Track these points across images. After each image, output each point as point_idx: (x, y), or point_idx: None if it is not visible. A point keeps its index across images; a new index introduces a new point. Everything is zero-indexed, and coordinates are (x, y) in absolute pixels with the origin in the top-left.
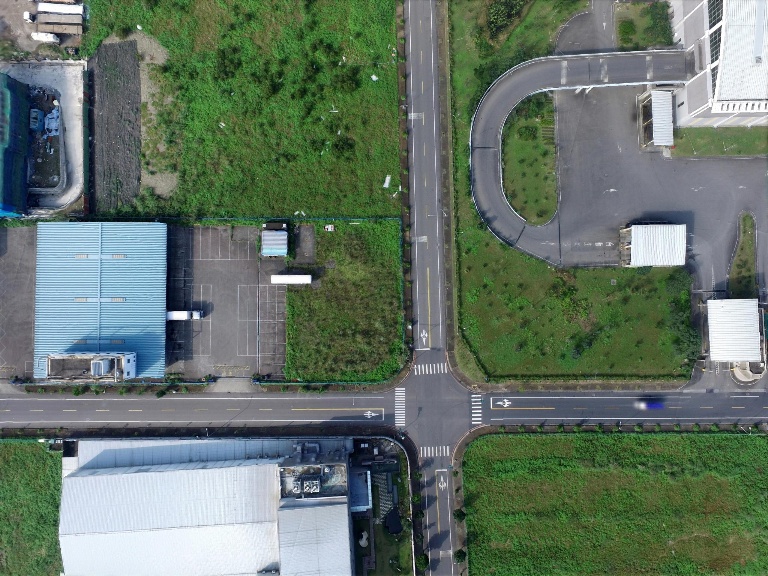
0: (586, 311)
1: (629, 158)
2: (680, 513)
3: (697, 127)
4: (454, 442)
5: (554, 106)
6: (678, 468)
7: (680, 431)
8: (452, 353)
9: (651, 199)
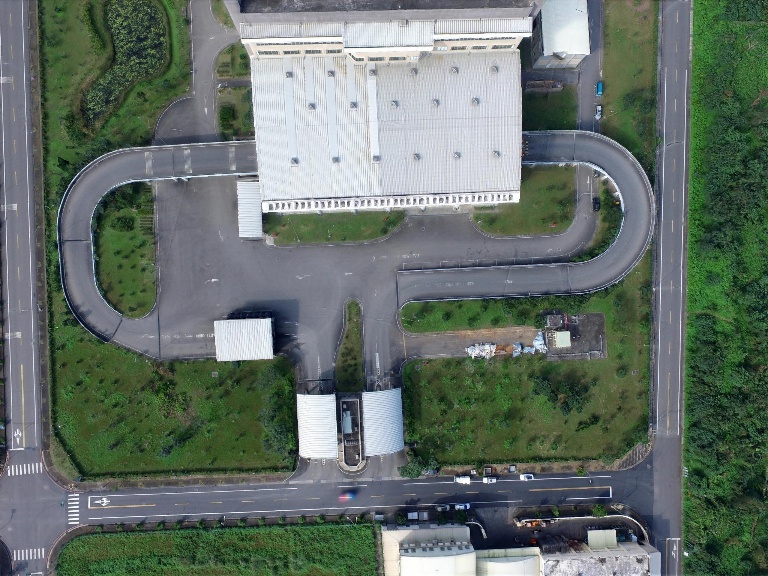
0: (182, 406)
1: (231, 247)
2: None
3: (301, 214)
4: (50, 544)
5: (154, 195)
6: (279, 563)
7: (284, 524)
8: (47, 452)
9: (254, 288)
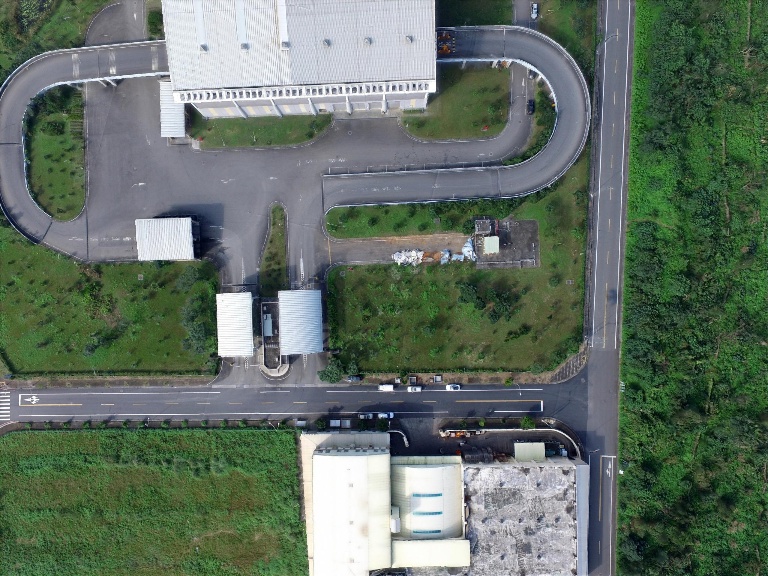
0: (107, 307)
1: (157, 151)
2: (203, 510)
3: (227, 118)
4: None
5: (84, 100)
6: (200, 464)
7: (207, 427)
8: None
9: (180, 192)
